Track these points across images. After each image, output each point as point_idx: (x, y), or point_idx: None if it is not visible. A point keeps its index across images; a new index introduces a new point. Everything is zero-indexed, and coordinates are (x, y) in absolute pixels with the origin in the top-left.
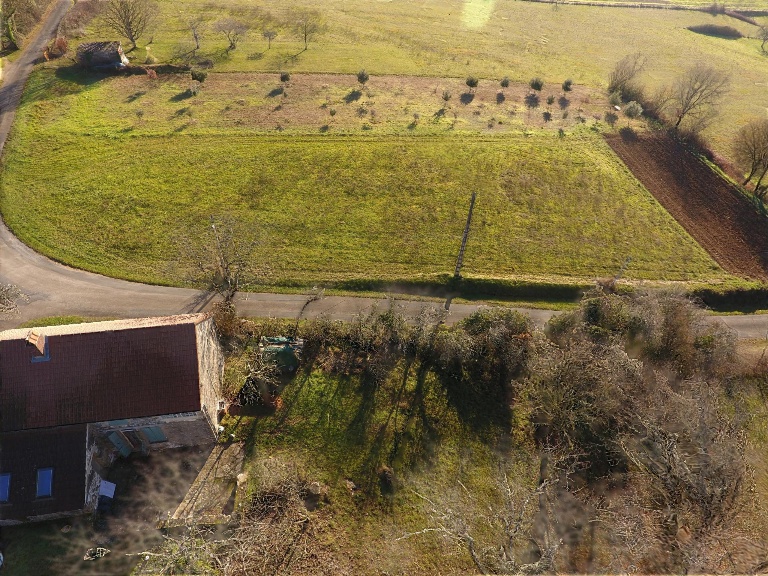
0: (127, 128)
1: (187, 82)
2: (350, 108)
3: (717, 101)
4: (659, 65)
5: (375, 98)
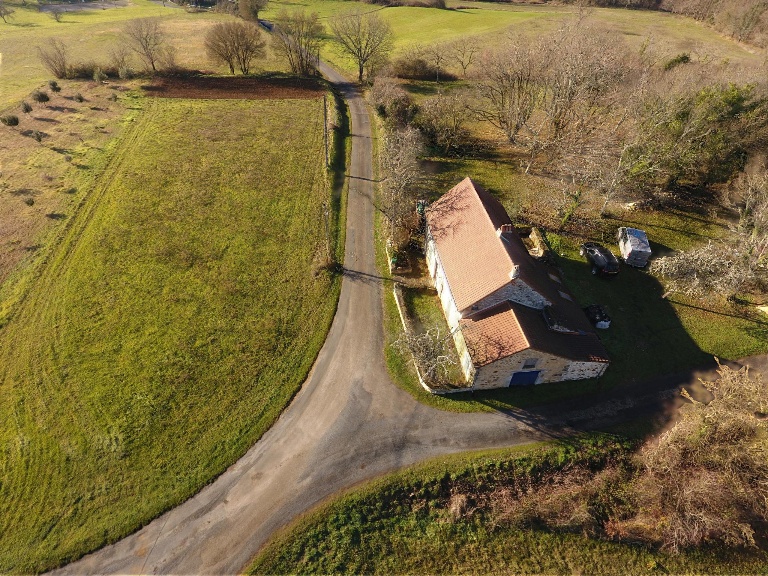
0: None
1: None
2: (7, 199)
3: (160, 40)
4: (6, 59)
5: None
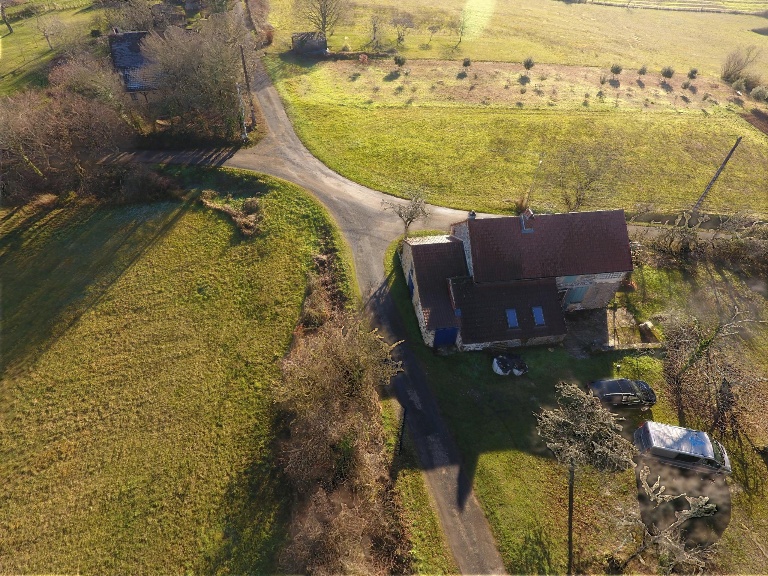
0: (368, 101)
1: (386, 66)
2: (528, 89)
3: None
4: None
5: (542, 81)
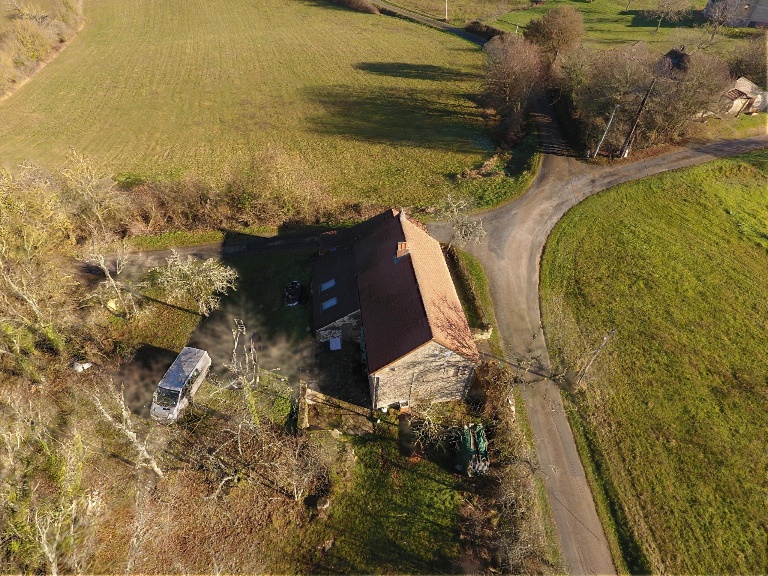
0: None
1: None
2: None
3: None
4: None
5: None
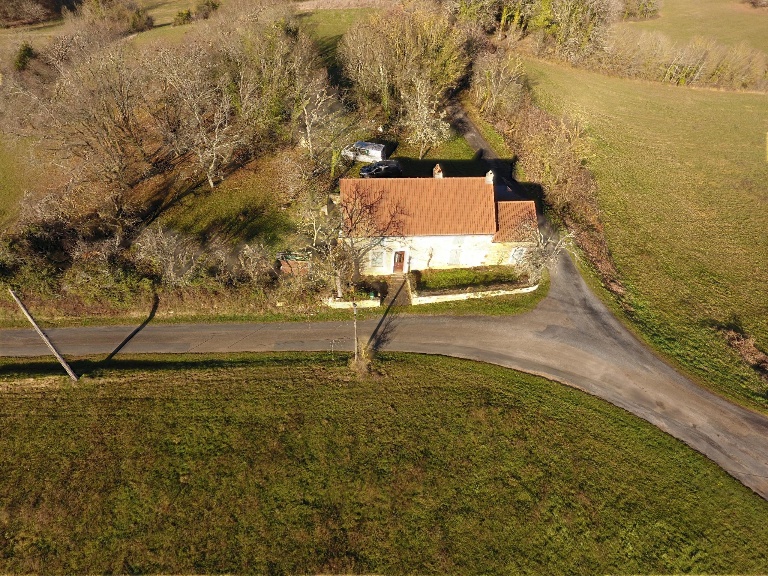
0: None
1: None
2: None
3: None
4: None
5: None
